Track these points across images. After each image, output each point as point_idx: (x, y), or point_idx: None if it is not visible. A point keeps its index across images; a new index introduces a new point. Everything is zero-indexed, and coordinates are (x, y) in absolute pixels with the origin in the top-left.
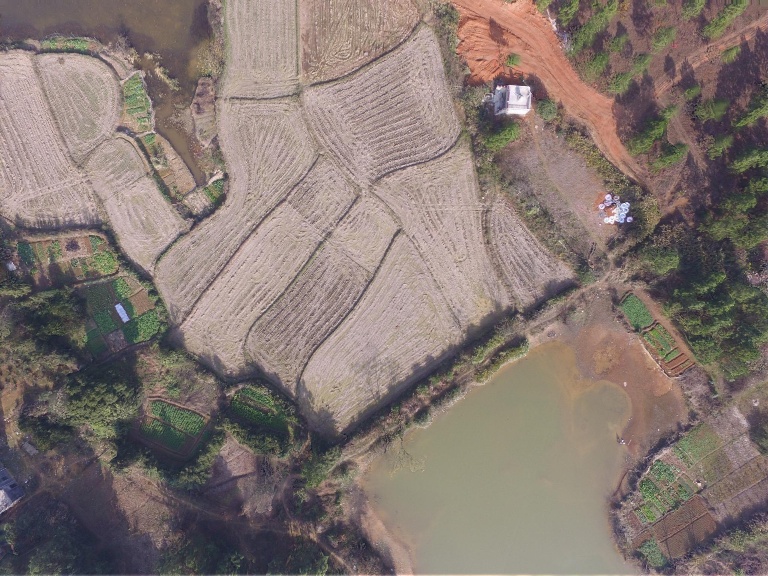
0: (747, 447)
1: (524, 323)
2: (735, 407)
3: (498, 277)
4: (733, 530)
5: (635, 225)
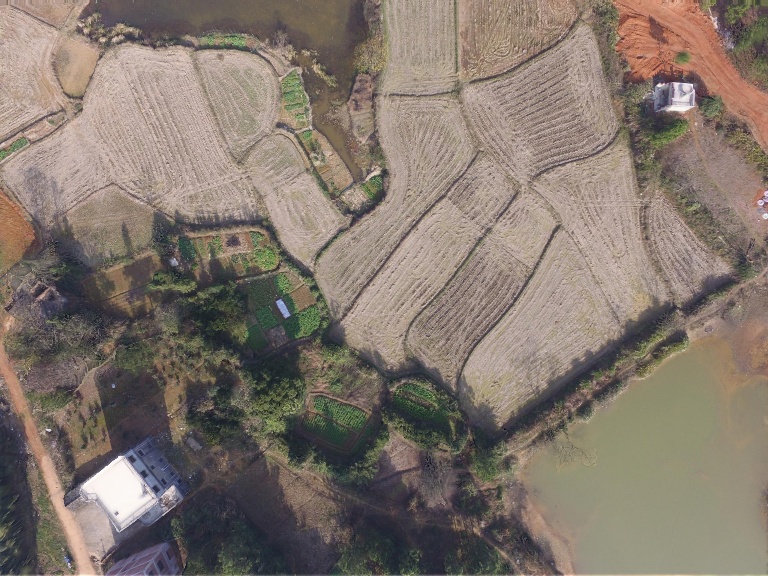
0: None
1: (684, 318)
2: None
3: (656, 273)
4: None
5: None
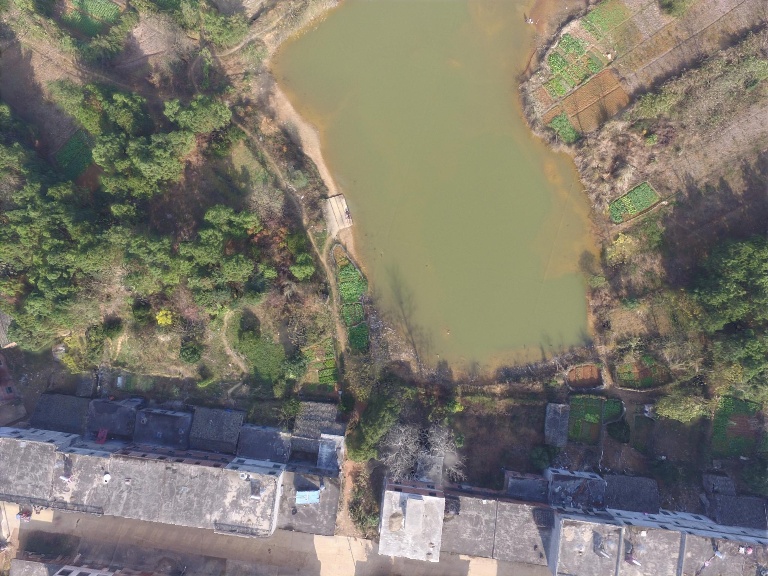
0: (657, 16)
1: None
2: None
3: None
4: (644, 94)
5: None
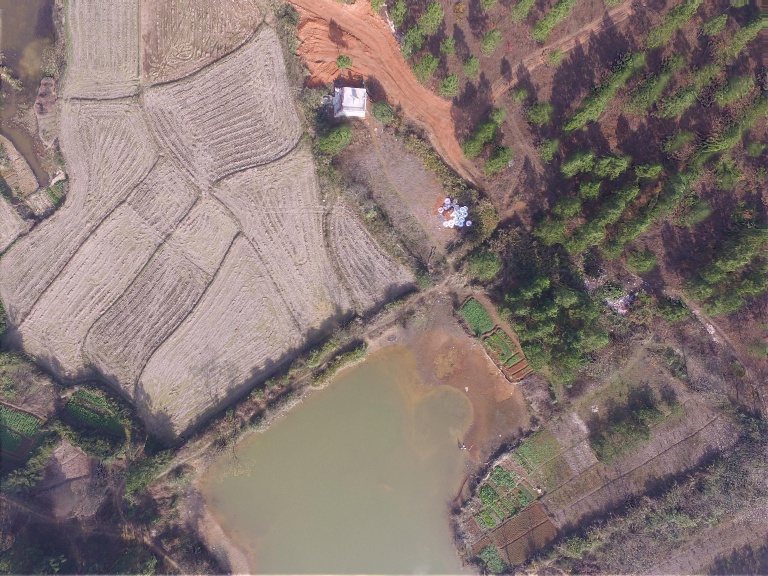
0: (587, 453)
1: (362, 327)
2: (575, 413)
3: (338, 280)
4: (571, 537)
5: (472, 229)
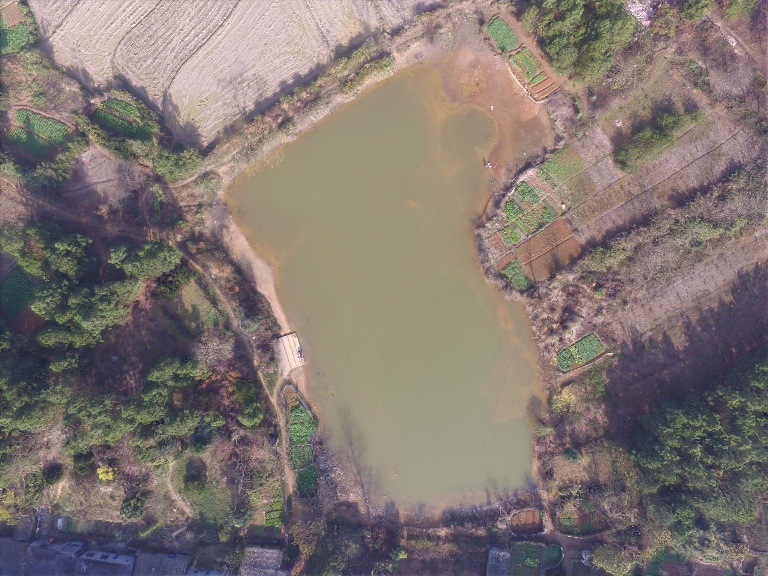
0: (611, 169)
1: (390, 40)
2: (599, 128)
3: None
4: (595, 248)
5: None
